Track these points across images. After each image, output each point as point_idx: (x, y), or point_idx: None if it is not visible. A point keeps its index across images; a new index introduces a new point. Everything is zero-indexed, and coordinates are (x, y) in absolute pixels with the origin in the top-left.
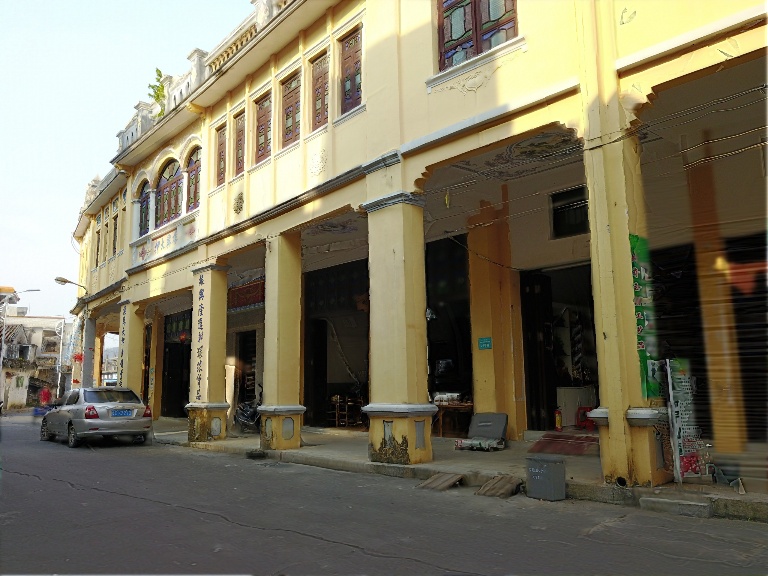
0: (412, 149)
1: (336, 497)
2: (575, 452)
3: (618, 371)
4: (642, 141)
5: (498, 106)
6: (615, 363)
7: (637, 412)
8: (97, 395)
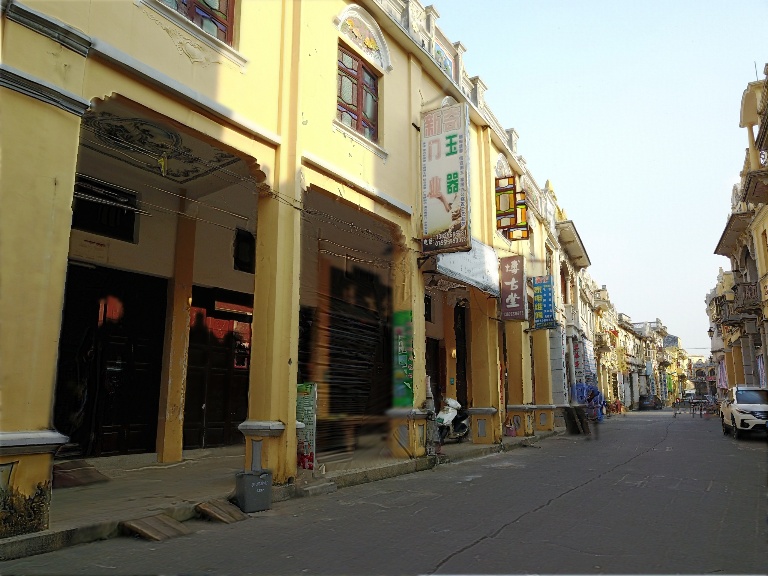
0: (110, 57)
1: (205, 570)
2: (72, 483)
3: (296, 391)
4: (302, 217)
5: (215, 101)
6: (295, 384)
7: (299, 423)
8: None
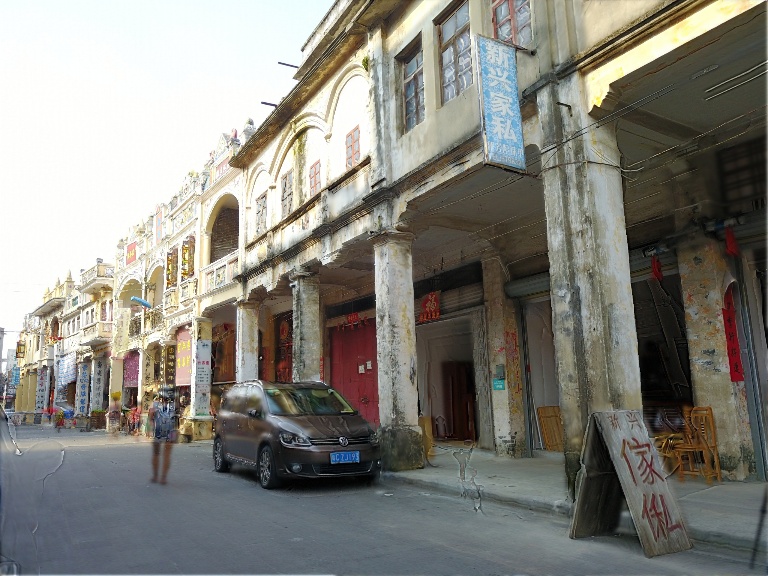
0: None
1: None
2: None
3: None
4: None
5: None
6: None
7: None
8: (8, 410)
